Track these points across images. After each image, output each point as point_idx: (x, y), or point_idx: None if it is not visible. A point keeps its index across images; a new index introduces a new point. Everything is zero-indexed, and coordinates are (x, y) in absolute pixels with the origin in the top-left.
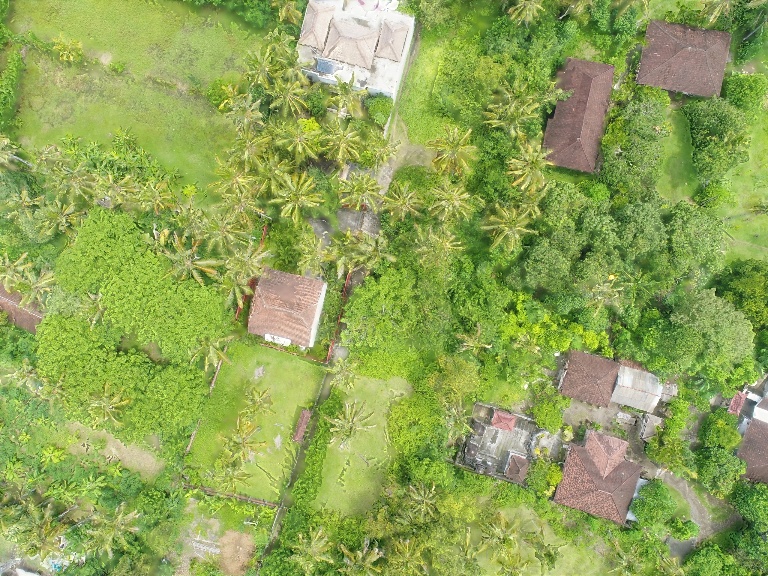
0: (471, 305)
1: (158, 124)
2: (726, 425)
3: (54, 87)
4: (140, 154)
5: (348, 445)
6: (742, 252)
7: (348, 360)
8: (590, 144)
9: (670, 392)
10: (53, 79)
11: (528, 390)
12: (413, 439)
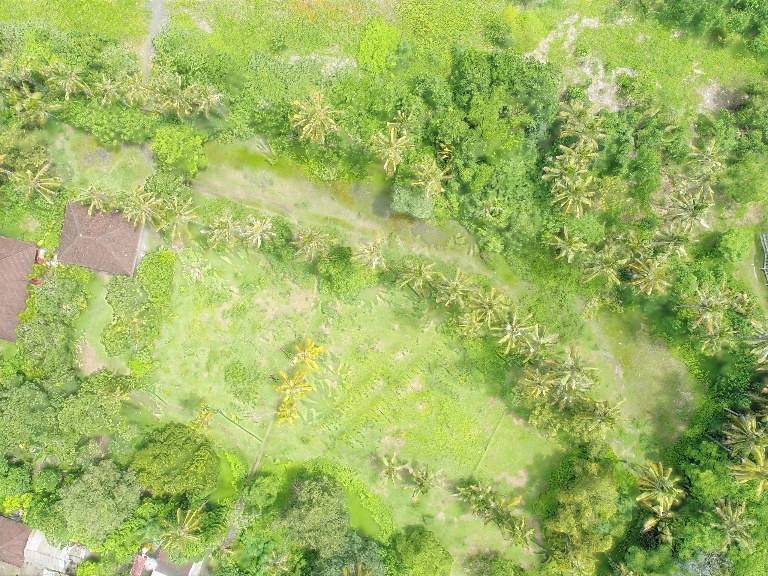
0: None
1: None
2: None
3: None
4: None
5: None
6: (175, 415)
7: None
8: (9, 318)
9: (77, 555)
10: None
11: None
12: None
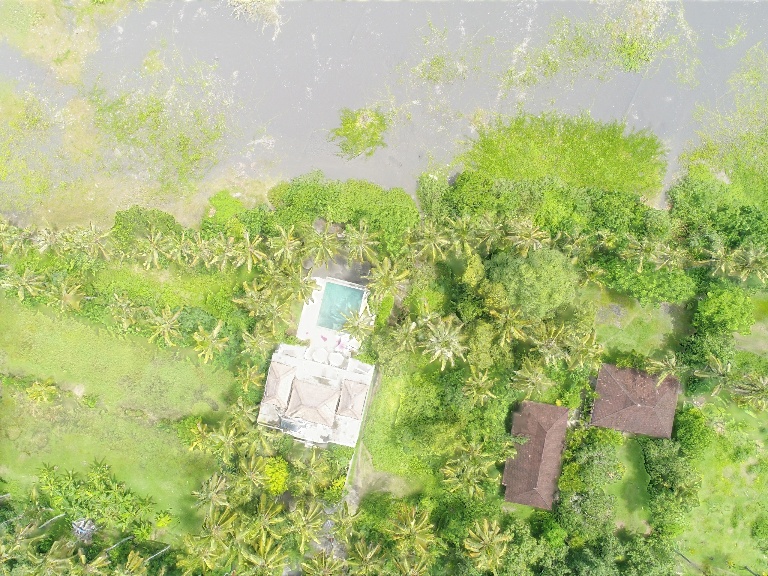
0: None
1: (131, 452)
2: None
3: (30, 417)
4: (114, 490)
5: None
6: (698, 573)
7: None
8: (547, 487)
9: None
10: (28, 410)
11: None
12: None
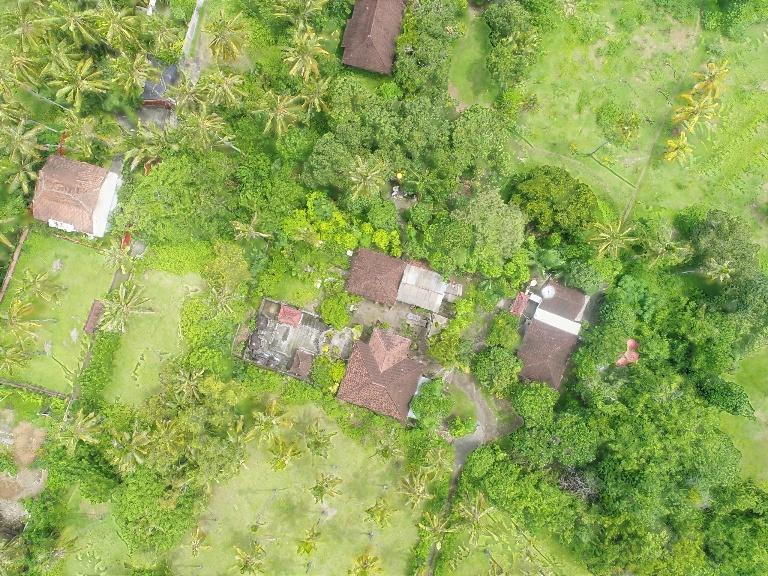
0: (252, 196)
1: None
2: (506, 324)
3: None
4: None
5: (113, 324)
6: (541, 160)
7: (143, 254)
8: (384, 44)
9: (455, 292)
10: None
11: (320, 289)
12: (203, 333)
